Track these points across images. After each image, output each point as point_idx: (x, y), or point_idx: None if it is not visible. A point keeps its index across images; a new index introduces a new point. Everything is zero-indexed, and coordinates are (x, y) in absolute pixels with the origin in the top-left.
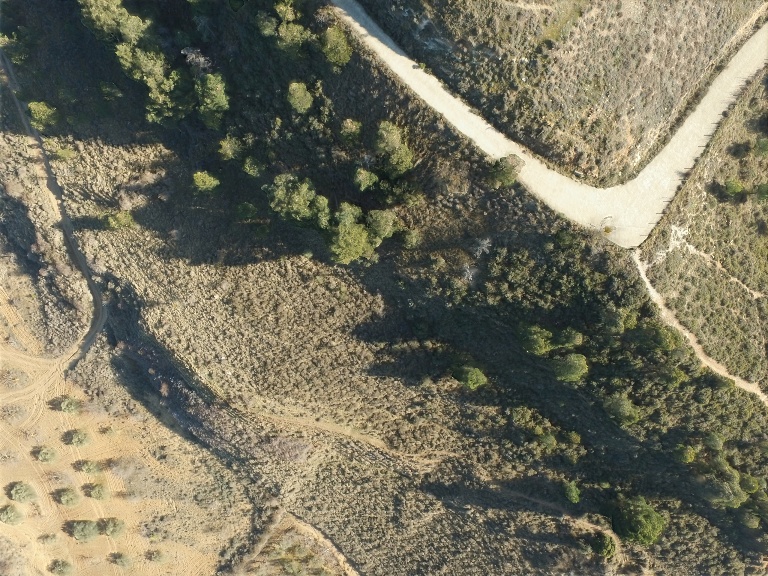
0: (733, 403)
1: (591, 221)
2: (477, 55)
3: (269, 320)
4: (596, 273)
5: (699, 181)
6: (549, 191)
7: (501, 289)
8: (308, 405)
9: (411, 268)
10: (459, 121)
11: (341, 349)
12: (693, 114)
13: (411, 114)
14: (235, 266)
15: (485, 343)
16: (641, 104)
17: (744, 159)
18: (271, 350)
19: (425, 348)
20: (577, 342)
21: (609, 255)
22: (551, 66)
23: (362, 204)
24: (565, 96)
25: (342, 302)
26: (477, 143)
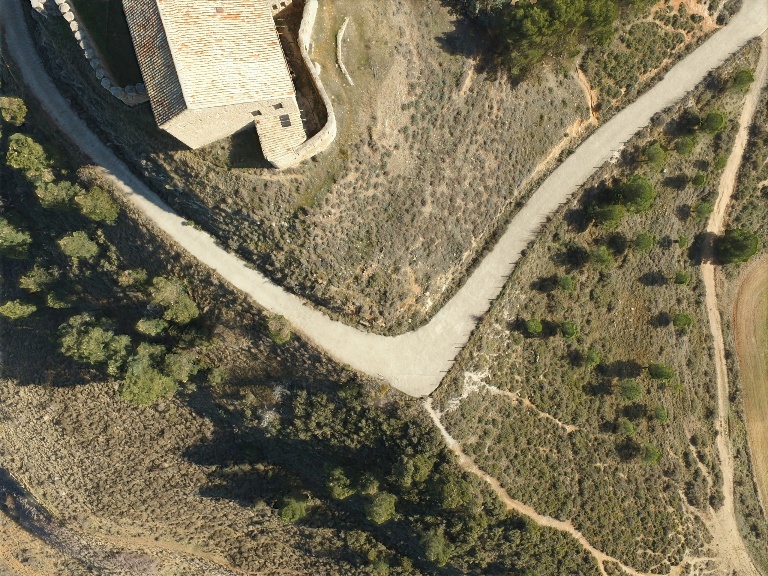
0: (544, 543)
1: (379, 371)
2: (236, 219)
3: (100, 441)
4: (391, 420)
5: (496, 323)
6: (333, 342)
7: (309, 427)
8: (145, 525)
9: (226, 399)
10: (234, 276)
11: (173, 471)
12: (491, 254)
13: (186, 268)
14: (63, 387)
15: (311, 470)
16: (425, 253)
17: (552, 292)
18: (103, 472)
19: (257, 470)
20: (370, 493)
21: (398, 405)
22: (313, 229)
23: (167, 340)
24: (335, 254)
25: (172, 424)
26: (254, 297)
